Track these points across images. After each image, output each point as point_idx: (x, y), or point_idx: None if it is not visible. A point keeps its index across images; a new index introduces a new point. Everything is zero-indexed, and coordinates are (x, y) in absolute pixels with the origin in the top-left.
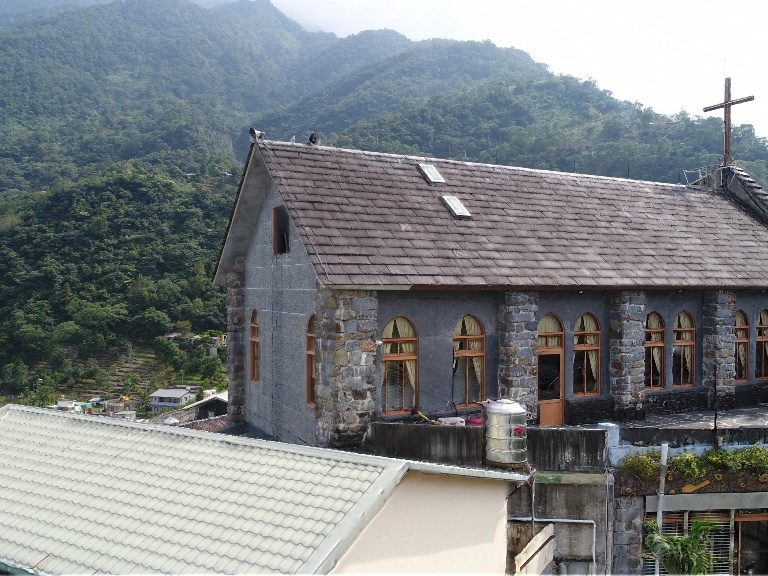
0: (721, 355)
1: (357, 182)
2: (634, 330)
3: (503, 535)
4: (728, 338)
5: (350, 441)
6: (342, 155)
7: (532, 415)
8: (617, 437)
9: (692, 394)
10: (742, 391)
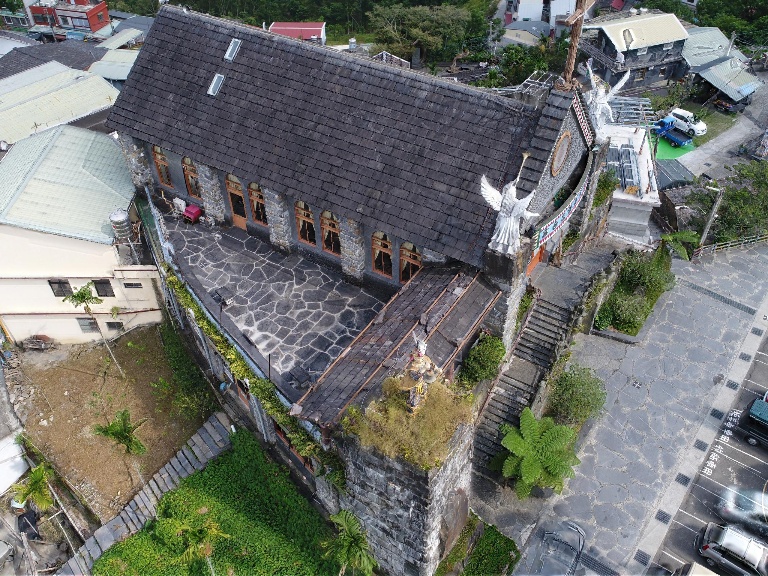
0: (345, 251)
1: (181, 52)
2: (273, 206)
3: (113, 256)
4: (351, 244)
5: (139, 189)
6: (196, 24)
7: (217, 219)
8: (168, 252)
9: (332, 261)
10: (377, 281)
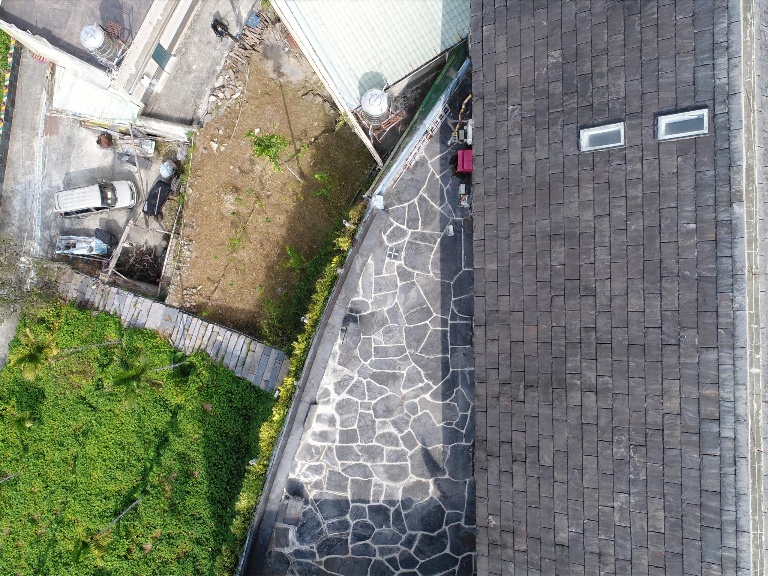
0: None
1: (644, 5)
2: None
3: None
4: None
5: None
6: None
7: None
8: None
9: None
10: None
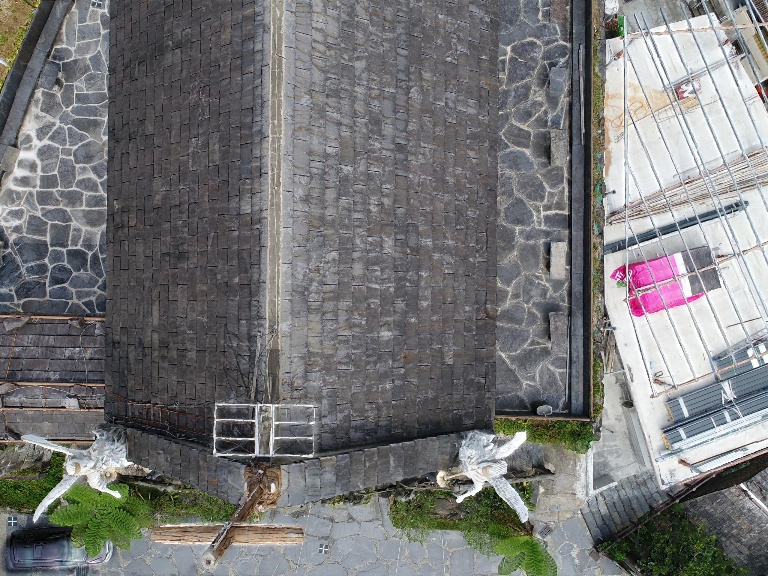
0: None
1: None
2: None
3: None
4: None
5: None
6: None
7: None
8: None
9: None
10: None
